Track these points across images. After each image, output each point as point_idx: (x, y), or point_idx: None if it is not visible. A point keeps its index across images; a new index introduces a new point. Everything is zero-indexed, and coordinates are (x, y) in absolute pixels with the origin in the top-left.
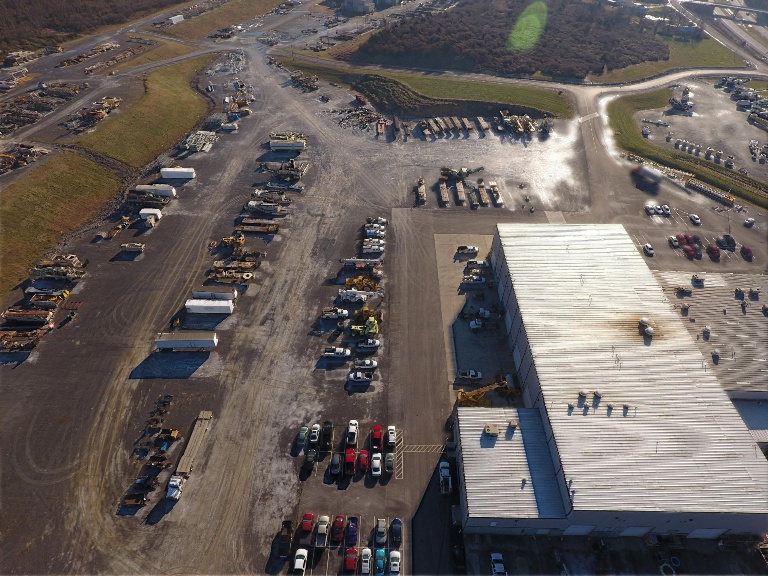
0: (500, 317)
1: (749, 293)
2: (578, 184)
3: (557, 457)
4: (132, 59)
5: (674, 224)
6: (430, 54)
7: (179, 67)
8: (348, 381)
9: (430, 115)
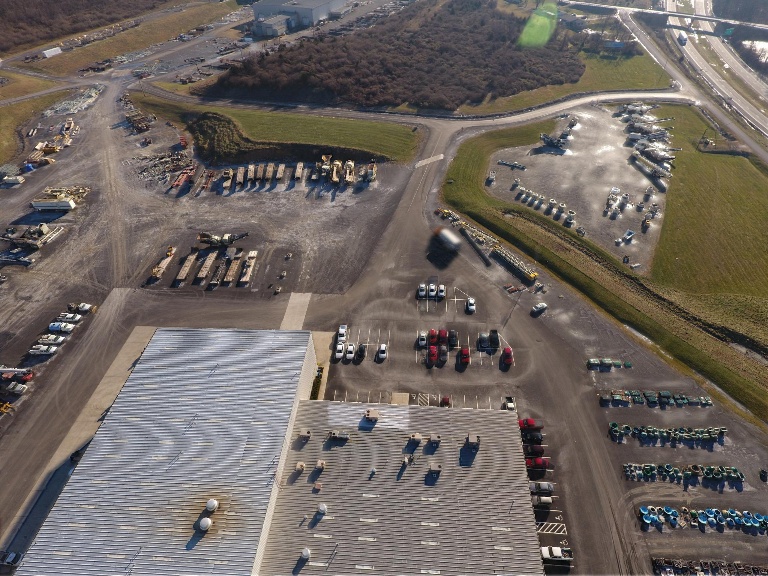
0: None
1: (428, 441)
2: (359, 253)
3: None
4: None
5: (440, 312)
6: (287, 86)
7: (14, 108)
8: None
9: (247, 161)
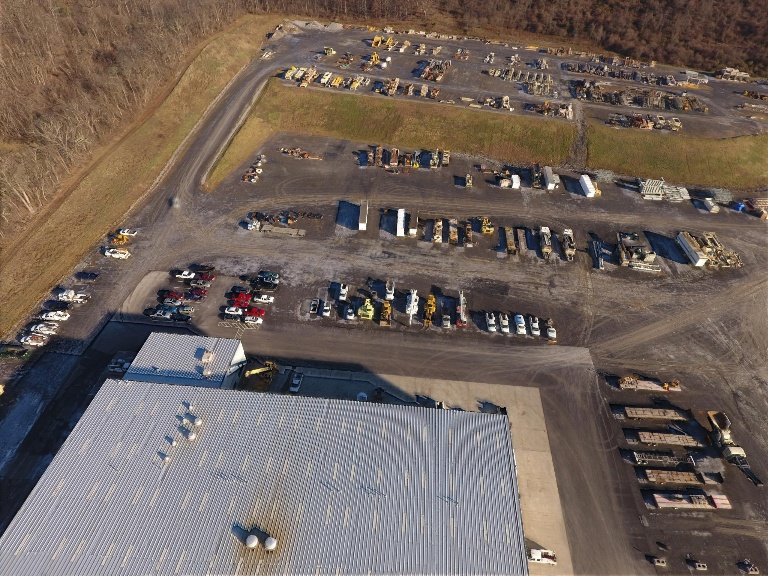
0: None
1: None
2: None
3: None
4: None
5: None
6: None
7: None
8: None
9: None
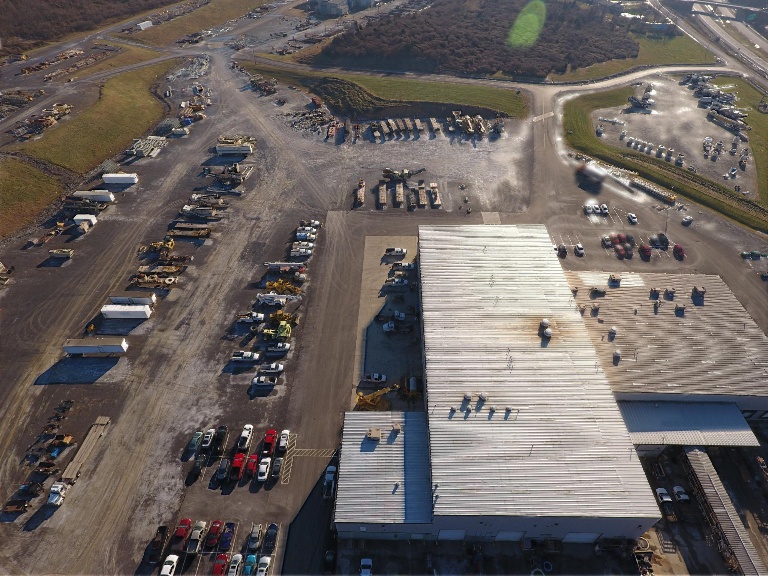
0: (416, 319)
1: (665, 293)
2: (520, 184)
3: (430, 461)
4: (94, 66)
5: (610, 223)
6: (391, 56)
7: (140, 73)
8: (252, 385)
9: (383, 117)
